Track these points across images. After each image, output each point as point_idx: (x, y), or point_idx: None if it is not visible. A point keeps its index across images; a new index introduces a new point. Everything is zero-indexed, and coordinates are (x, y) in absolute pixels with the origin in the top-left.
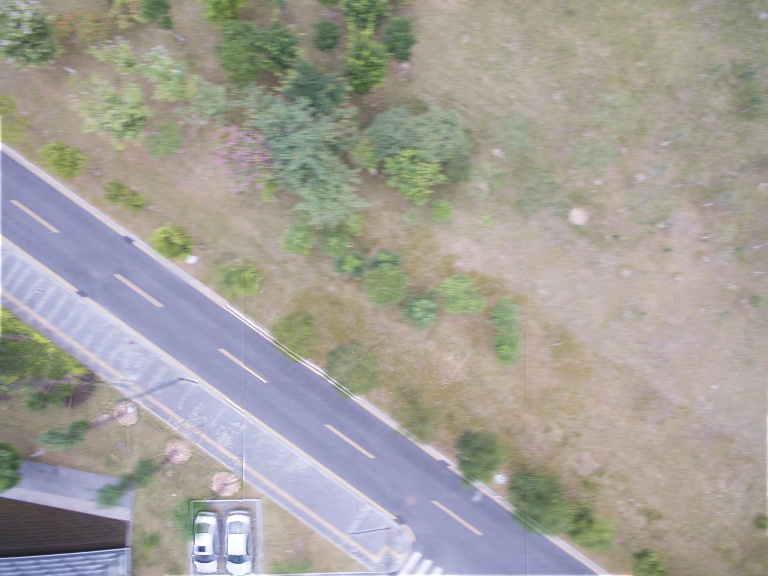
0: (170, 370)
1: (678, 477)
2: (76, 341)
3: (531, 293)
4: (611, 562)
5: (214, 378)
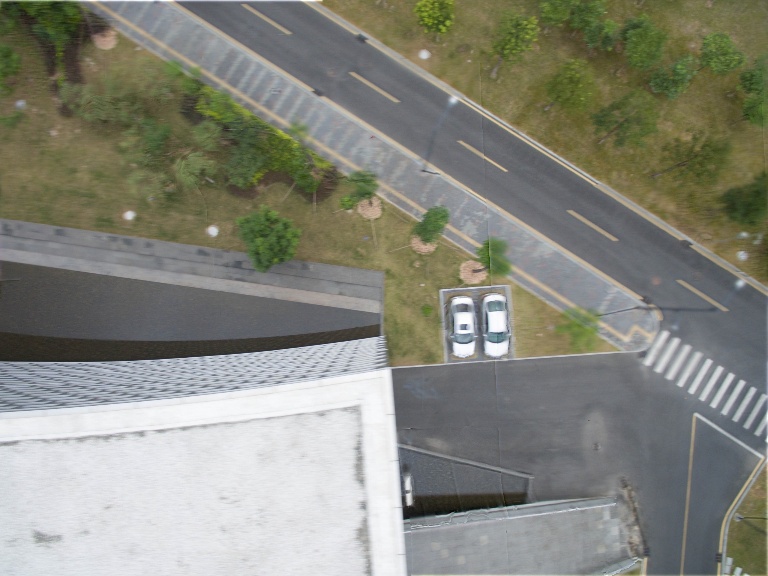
0: (411, 163)
1: None
2: (316, 139)
3: (764, 71)
4: None
5: (454, 170)
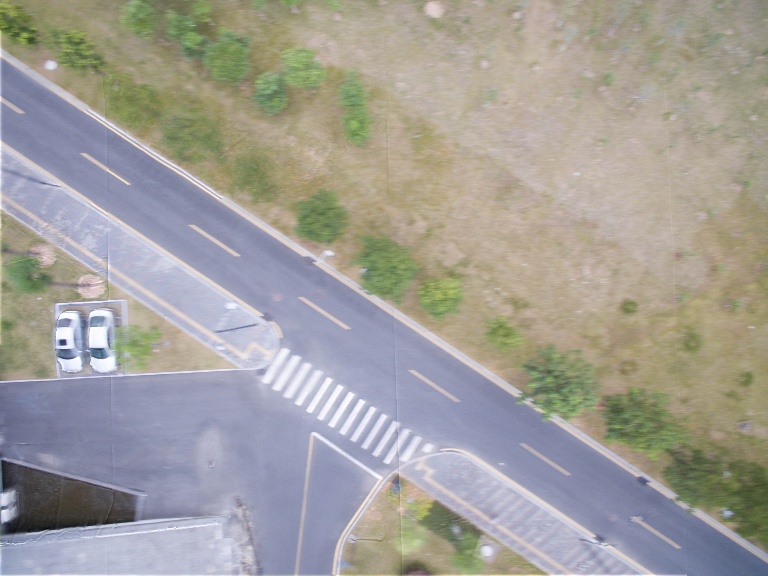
0: (32, 175)
1: (544, 265)
2: None
3: (392, 86)
4: (479, 352)
5: (77, 182)
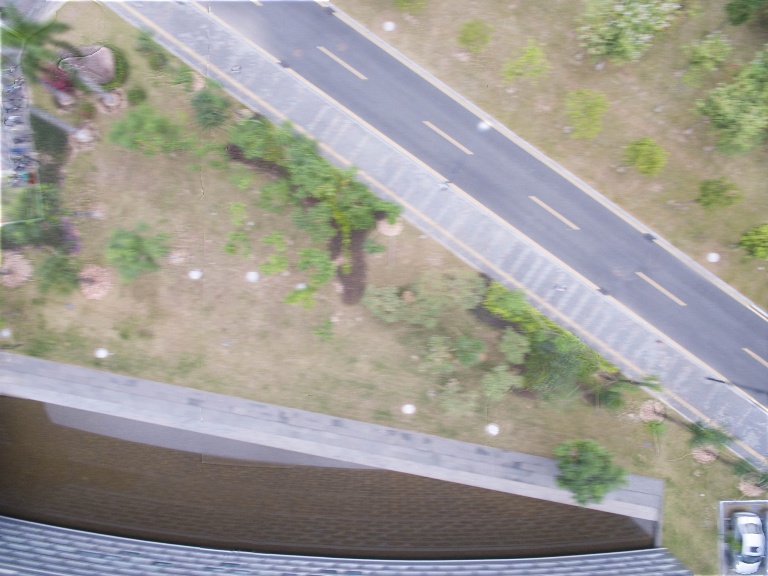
0: (696, 369)
1: None
2: (600, 339)
3: None
4: None
5: (738, 378)
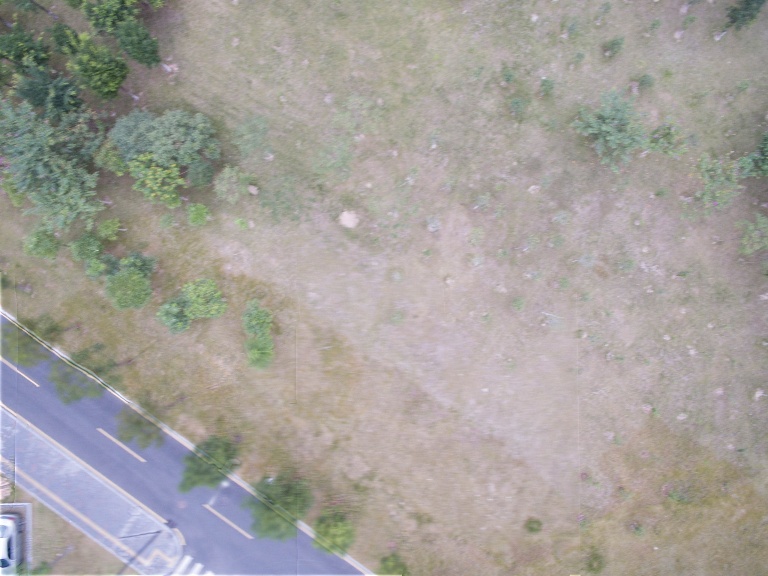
0: None
1: (449, 480)
2: None
3: (302, 296)
4: (381, 566)
5: None
